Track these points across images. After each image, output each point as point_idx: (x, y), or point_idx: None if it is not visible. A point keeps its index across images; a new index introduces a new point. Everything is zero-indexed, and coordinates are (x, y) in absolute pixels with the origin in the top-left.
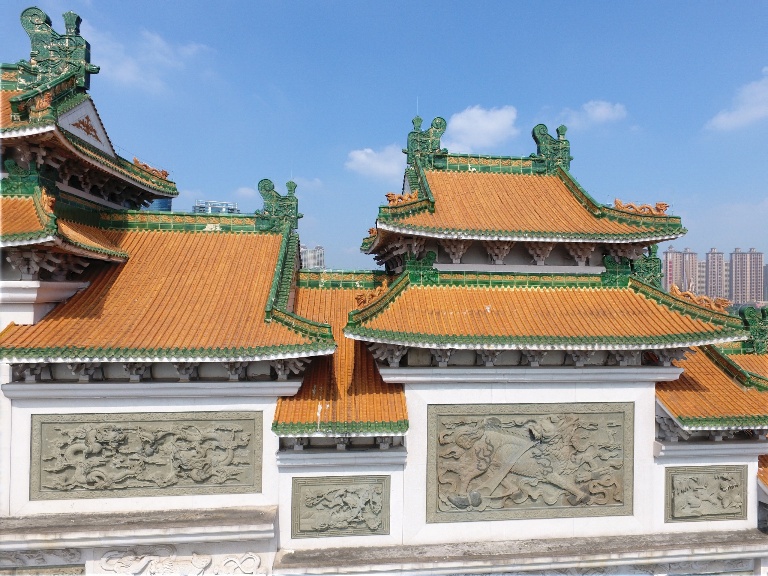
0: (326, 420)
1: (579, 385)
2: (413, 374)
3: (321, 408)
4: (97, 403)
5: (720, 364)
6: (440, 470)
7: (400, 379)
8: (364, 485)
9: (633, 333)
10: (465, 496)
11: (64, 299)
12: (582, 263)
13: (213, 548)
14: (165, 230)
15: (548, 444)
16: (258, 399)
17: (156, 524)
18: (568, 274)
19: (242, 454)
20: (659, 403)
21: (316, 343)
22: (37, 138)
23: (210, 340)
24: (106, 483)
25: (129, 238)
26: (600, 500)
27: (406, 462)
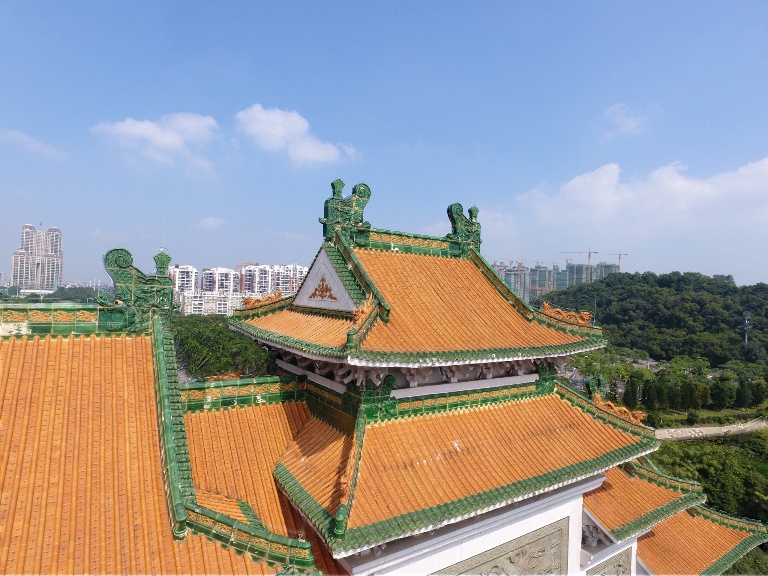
0: None
1: (532, 513)
2: (391, 560)
3: None
4: None
5: None
6: None
7: (374, 571)
8: None
9: (583, 456)
10: None
11: None
12: (521, 372)
13: None
14: None
15: None
16: None
17: None
18: (512, 386)
19: None
20: (587, 513)
21: (283, 573)
22: None
23: None
24: None
25: None
26: None
27: None
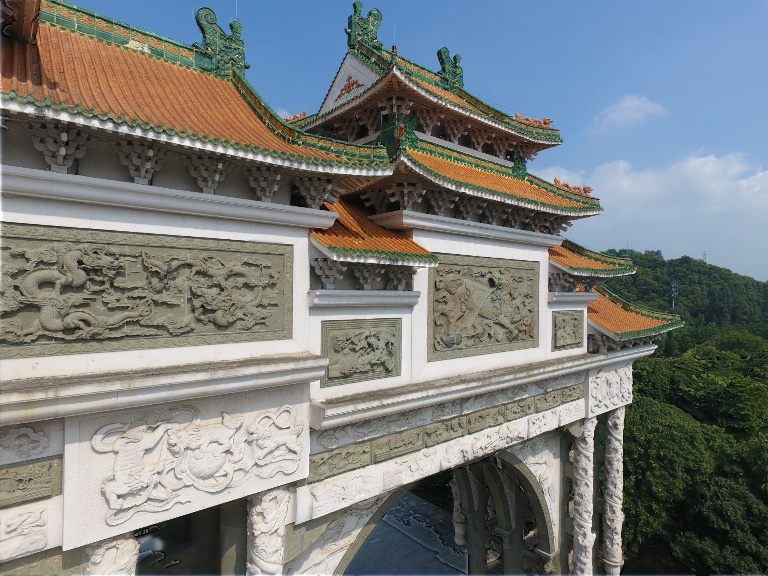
0: None
1: (514, 246)
2: (425, 218)
3: (357, 242)
4: (77, 212)
5: (565, 245)
6: (435, 313)
7: (415, 222)
8: (382, 328)
9: None
10: (453, 335)
11: None
12: (502, 157)
13: (244, 405)
14: (64, 28)
15: (500, 290)
16: (289, 231)
17: None
18: (495, 163)
19: (270, 294)
20: (552, 262)
21: None
22: None
23: None
24: (97, 329)
25: None
26: (523, 336)
27: (416, 304)
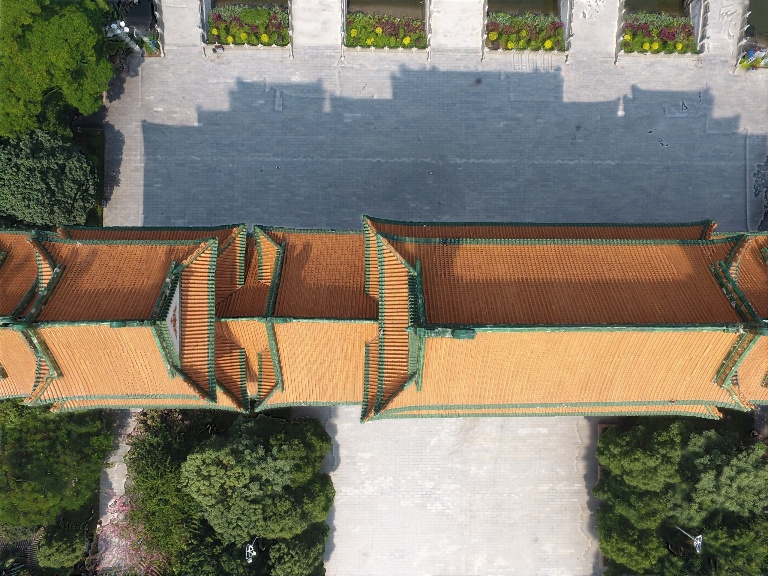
0: None
1: None
2: None
3: None
4: None
5: None
6: None
7: None
8: None
9: None
10: None
11: None
12: None
13: None
14: None
15: None
16: None
17: None
18: None
19: None
20: None
21: None
22: None
23: None
24: None
25: None
26: None
27: None
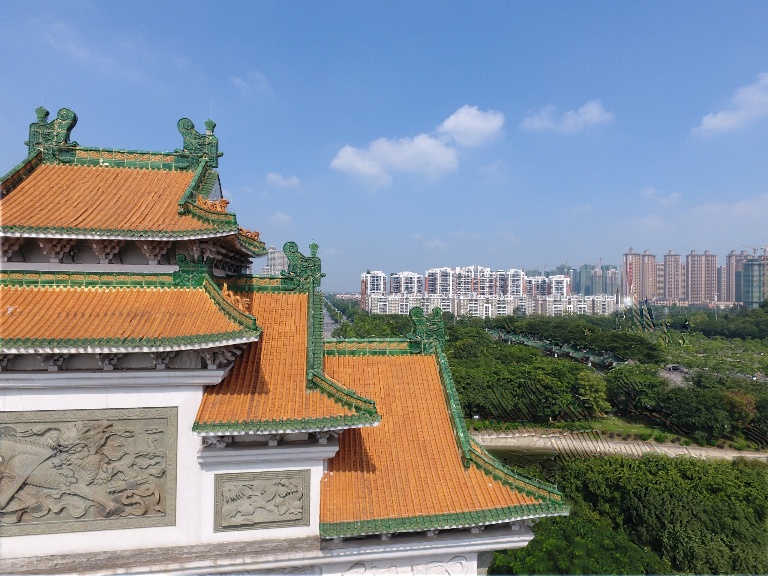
0: None
1: (112, 390)
2: None
3: None
4: None
5: (306, 366)
6: None
7: None
8: None
9: (148, 335)
10: None
11: None
12: (153, 262)
13: None
14: None
15: (69, 453)
16: None
17: None
18: (134, 273)
19: None
20: None
21: None
22: None
23: None
24: None
25: None
26: (137, 511)
27: None
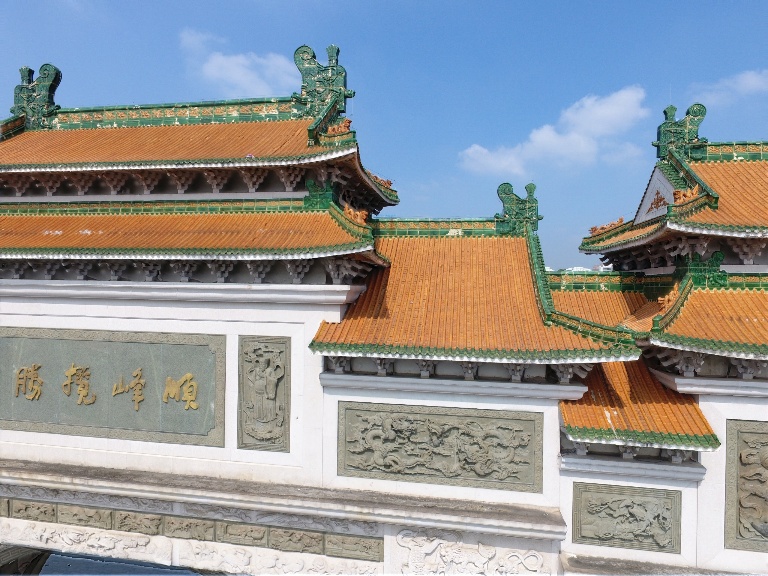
0: (621, 428)
1: None
2: (714, 385)
3: (609, 415)
4: (391, 395)
5: None
6: (741, 492)
7: (697, 390)
8: (651, 498)
9: None
10: None
11: (353, 300)
12: None
13: (497, 541)
14: (412, 236)
15: None
16: (539, 401)
17: (451, 511)
18: None
19: (522, 453)
20: None
21: (614, 348)
22: (337, 160)
23: (499, 341)
24: (400, 468)
25: (383, 244)
26: None
27: (702, 479)
